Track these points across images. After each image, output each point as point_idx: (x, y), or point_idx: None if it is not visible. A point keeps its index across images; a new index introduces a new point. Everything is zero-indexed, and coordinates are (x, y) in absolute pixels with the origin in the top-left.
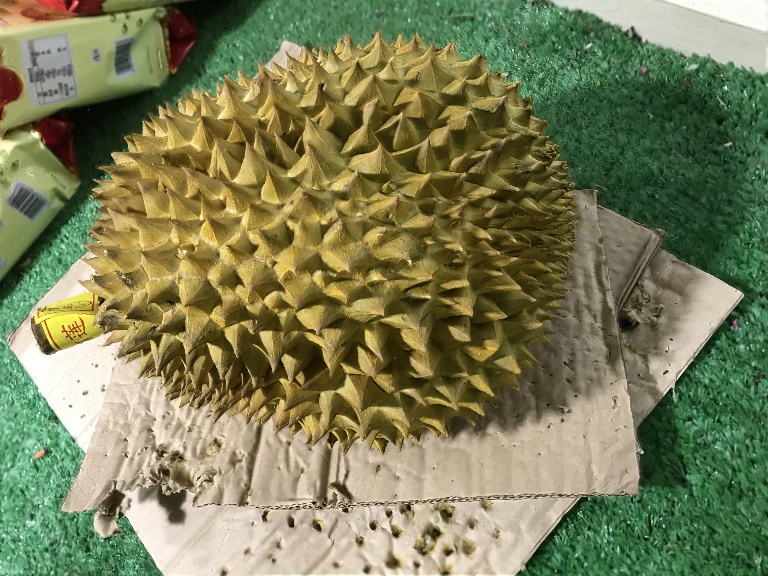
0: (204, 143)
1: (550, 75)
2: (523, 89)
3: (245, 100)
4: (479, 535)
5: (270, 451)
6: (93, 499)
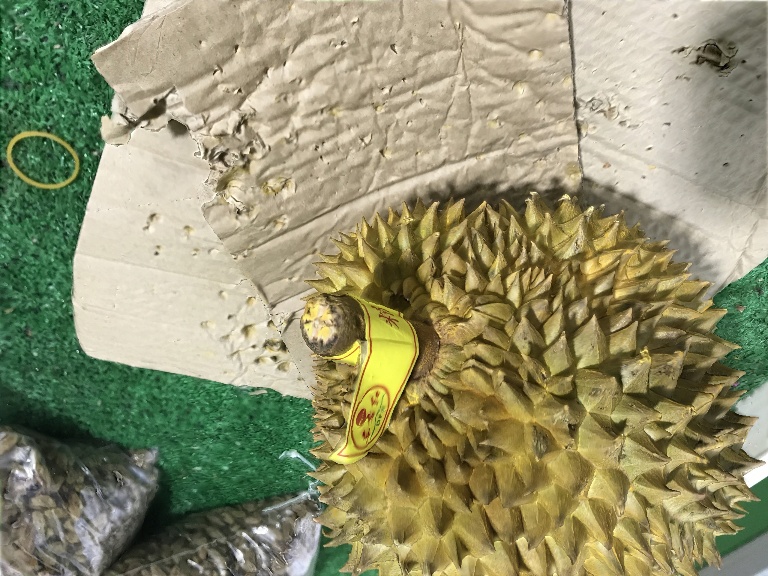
0: (587, 568)
1: (766, 326)
2: (759, 307)
3: (653, 552)
4: (295, 371)
5: (299, 244)
6: (135, 87)
